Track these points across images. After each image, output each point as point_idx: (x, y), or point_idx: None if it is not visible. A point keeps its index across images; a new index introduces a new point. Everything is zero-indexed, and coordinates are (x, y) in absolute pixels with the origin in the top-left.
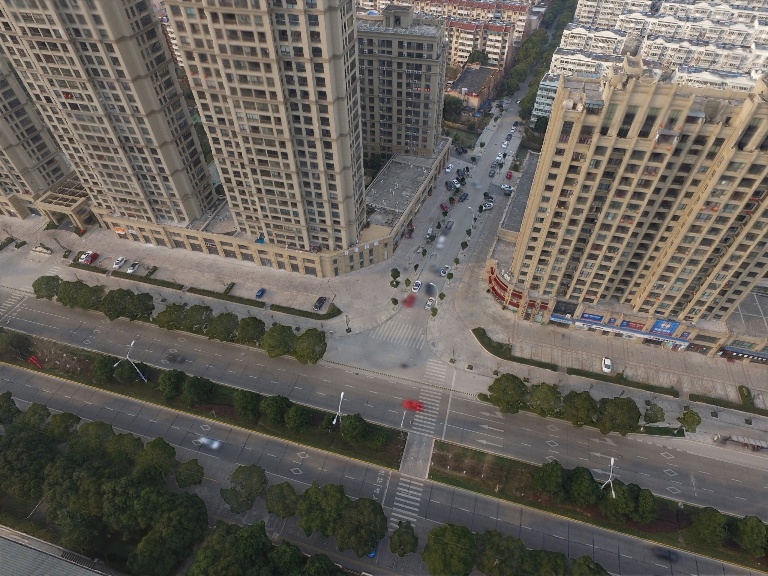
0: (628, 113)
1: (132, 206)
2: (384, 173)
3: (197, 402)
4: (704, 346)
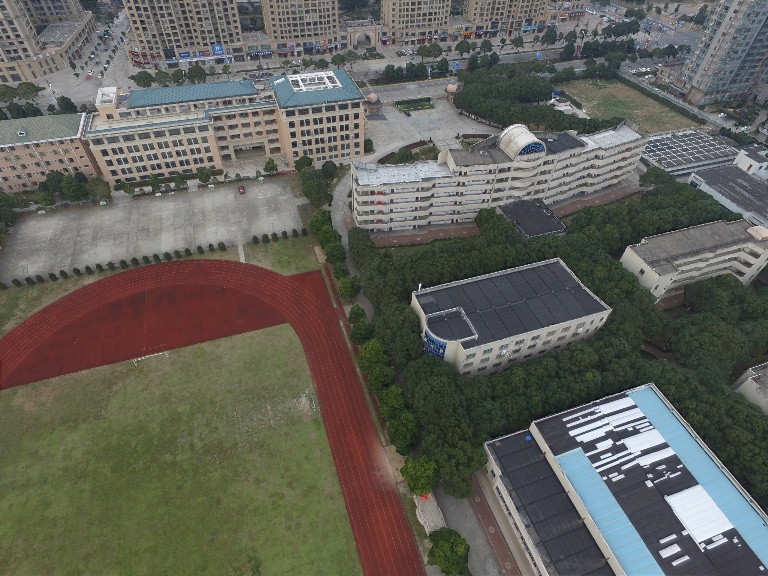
0: None
1: None
2: (48, 31)
3: None
4: (240, 56)
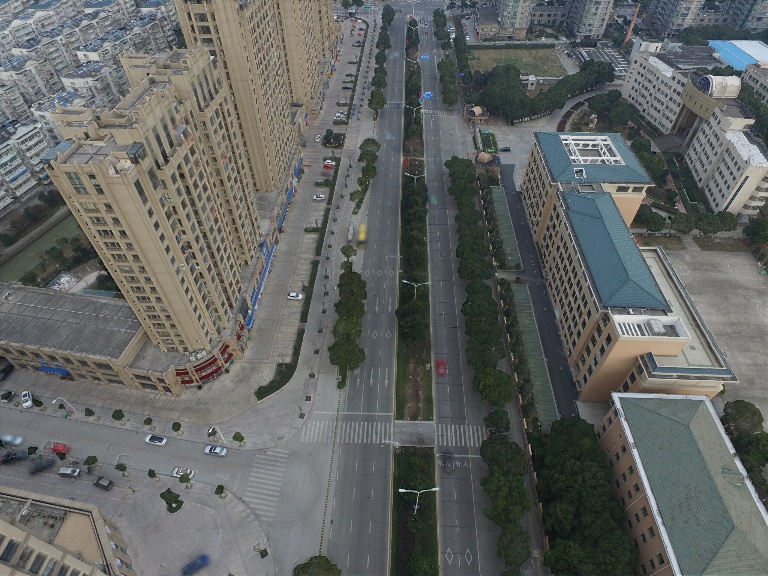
0: (155, 137)
1: None
2: None
3: None
4: (275, 239)
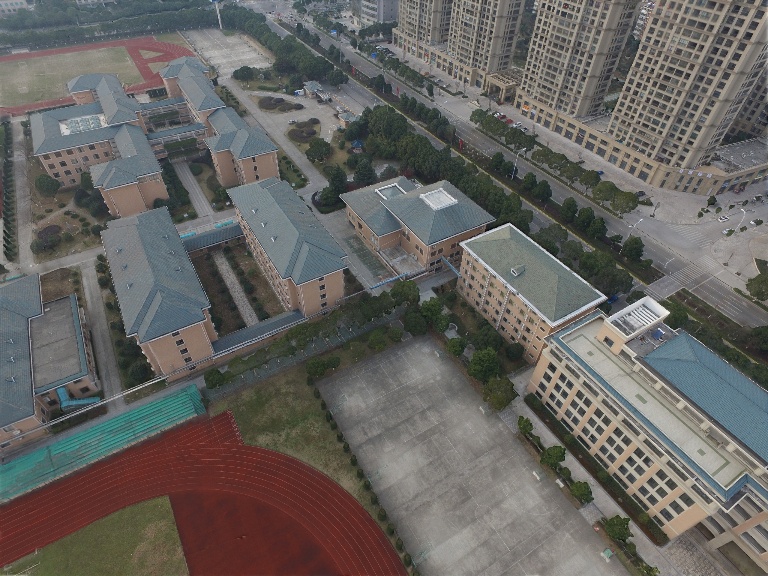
0: None
1: (547, 92)
2: (743, 144)
3: (540, 196)
4: None
